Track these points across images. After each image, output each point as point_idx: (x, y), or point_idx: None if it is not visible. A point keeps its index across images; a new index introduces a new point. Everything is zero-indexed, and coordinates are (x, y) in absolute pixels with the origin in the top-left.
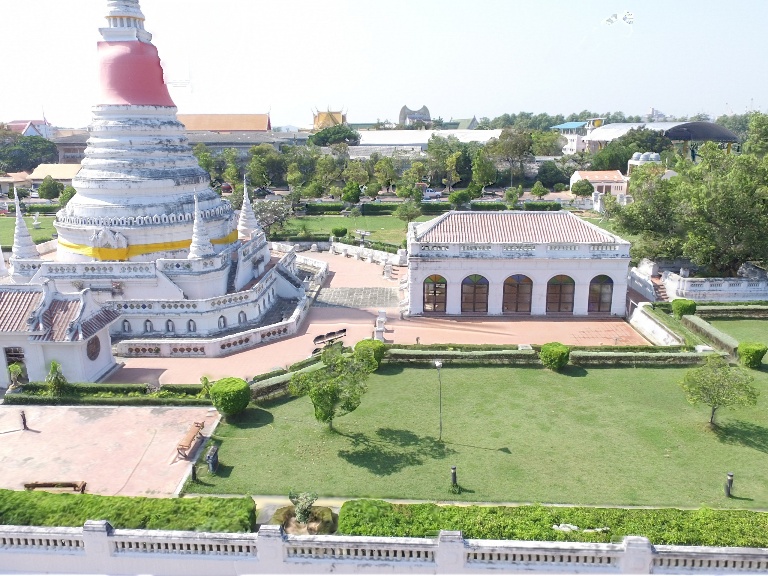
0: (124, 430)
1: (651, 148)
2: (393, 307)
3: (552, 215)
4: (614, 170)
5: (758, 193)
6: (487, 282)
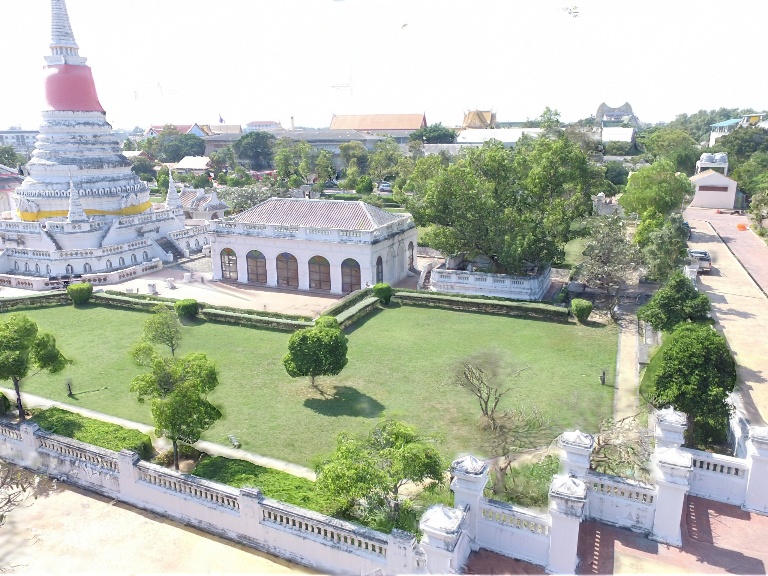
0: None
1: (755, 148)
2: None
3: (347, 204)
4: None
5: None
6: (264, 257)
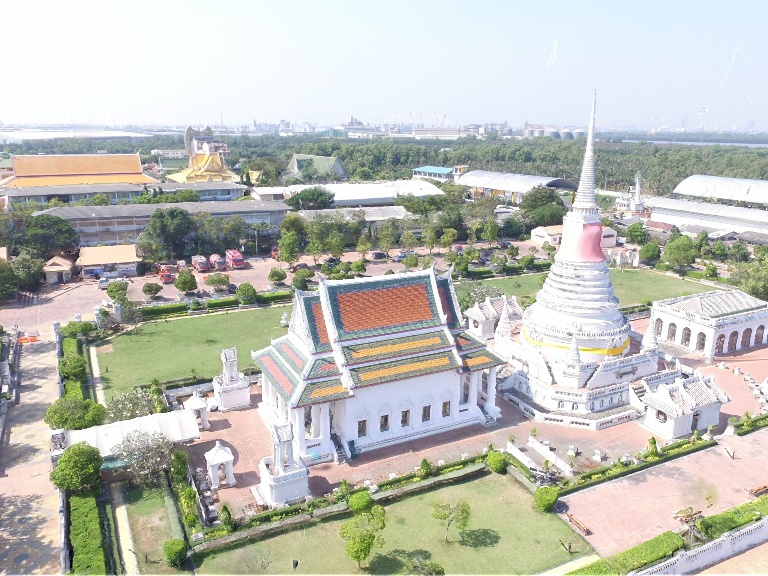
0: None
1: None
2: (690, 353)
3: (735, 293)
4: (560, 225)
5: None
6: (738, 334)
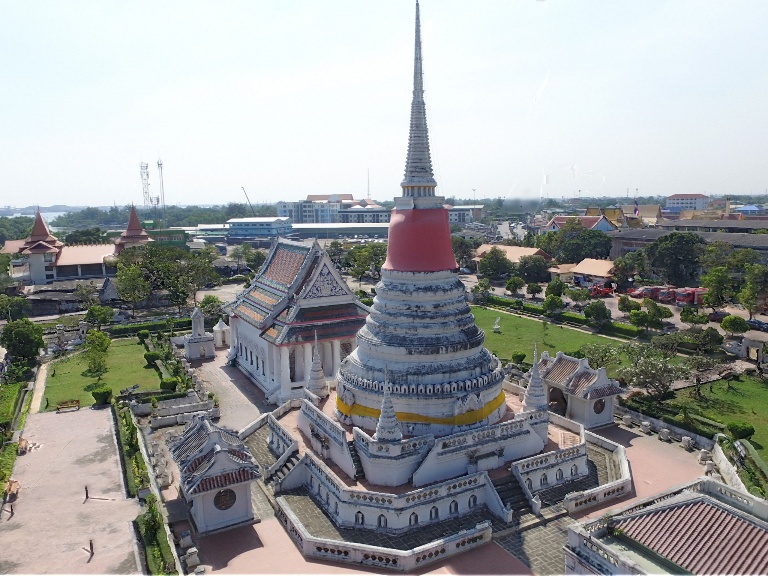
0: None
1: None
2: None
3: None
4: None
5: None
6: None
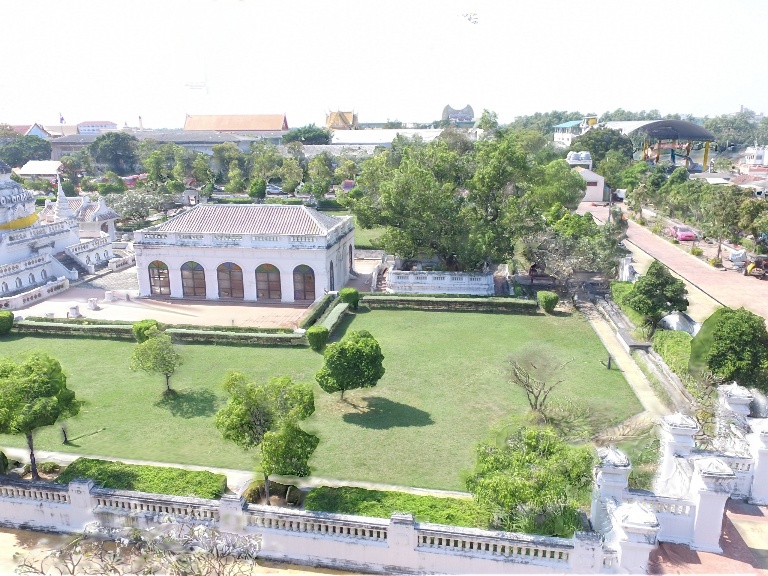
0: None
1: (606, 147)
2: None
3: (287, 209)
4: None
5: (441, 189)
6: (203, 269)
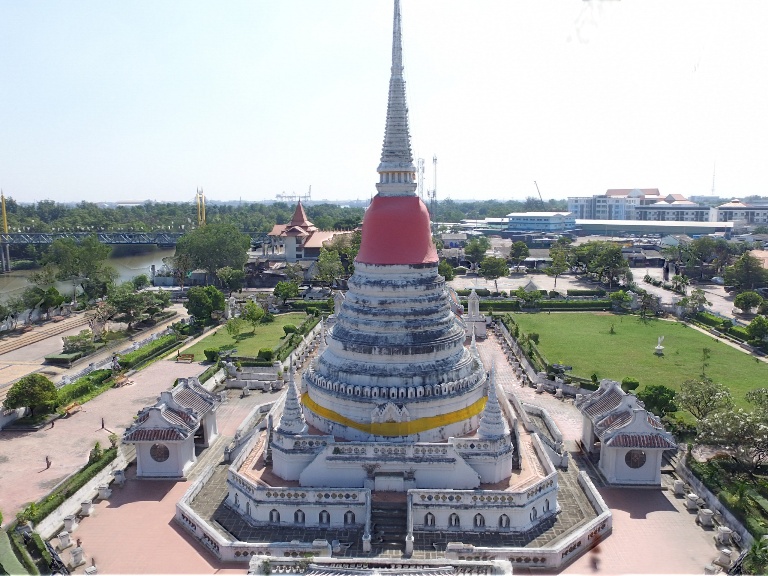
0: (7, 498)
1: None
2: None
3: None
4: None
5: None
6: None
